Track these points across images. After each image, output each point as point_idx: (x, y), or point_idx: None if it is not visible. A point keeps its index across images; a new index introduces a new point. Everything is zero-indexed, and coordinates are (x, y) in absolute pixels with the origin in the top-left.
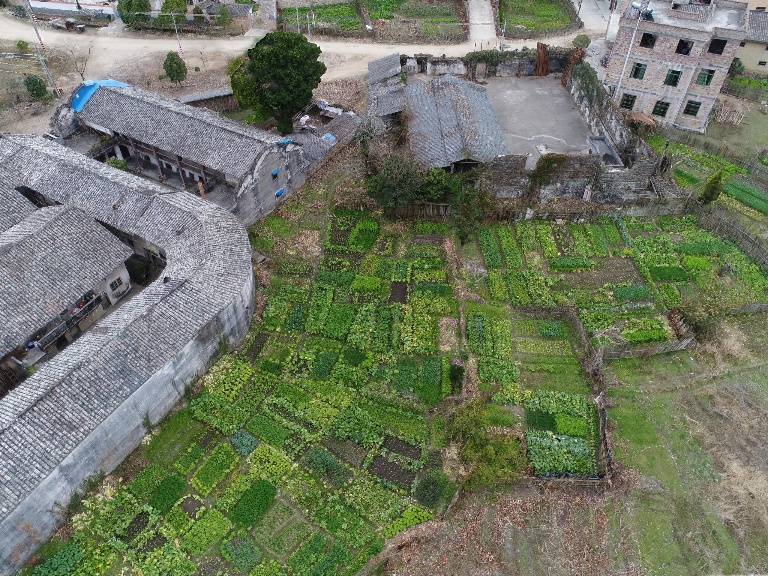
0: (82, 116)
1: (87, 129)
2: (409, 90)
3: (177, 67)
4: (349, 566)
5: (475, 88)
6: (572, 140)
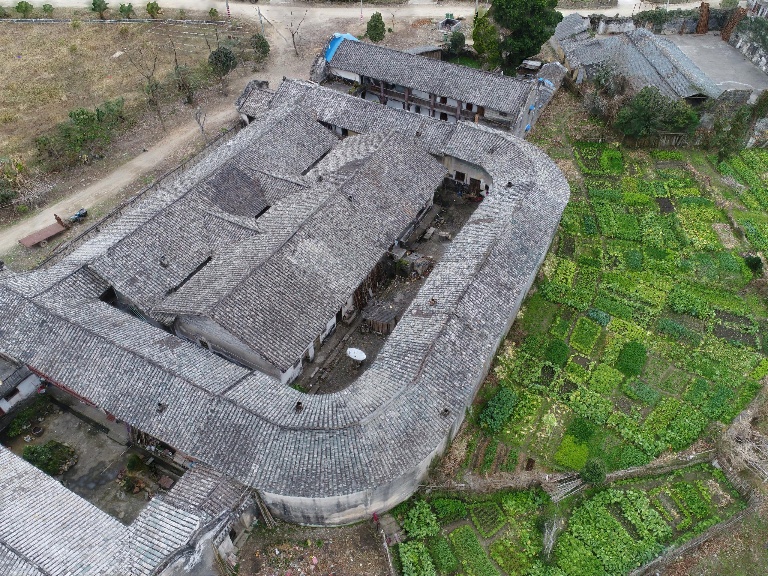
0: (333, 65)
1: (333, 78)
2: (606, 42)
3: (381, 27)
4: (737, 400)
5: (665, 40)
6: (757, 85)
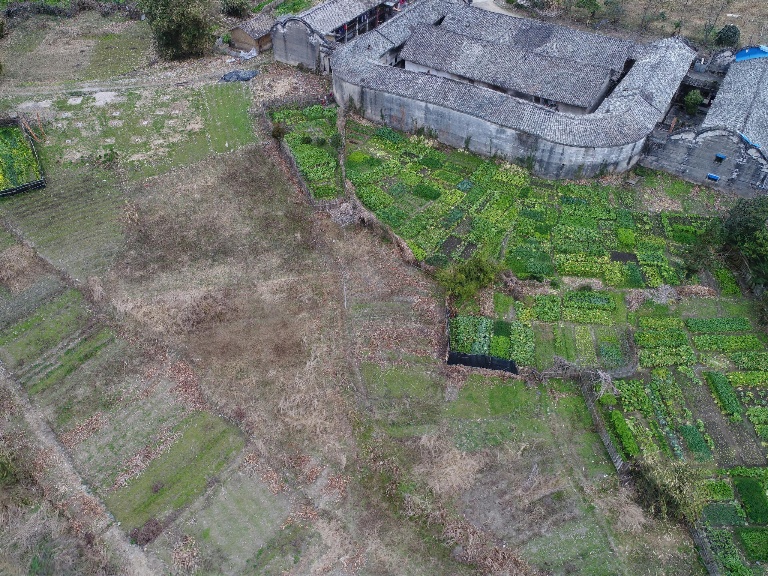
0: (733, 64)
1: None
2: None
3: None
4: None
5: None
6: None
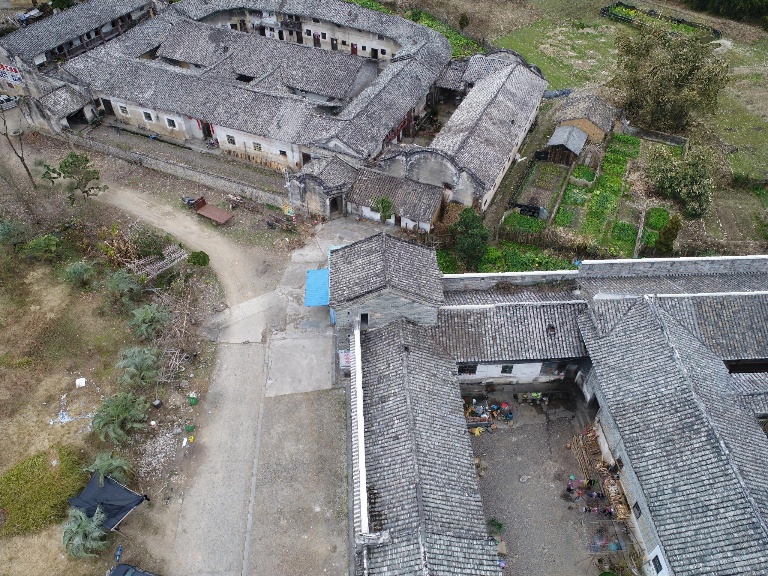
0: None
1: None
2: None
3: None
4: (368, 3)
5: None
6: None
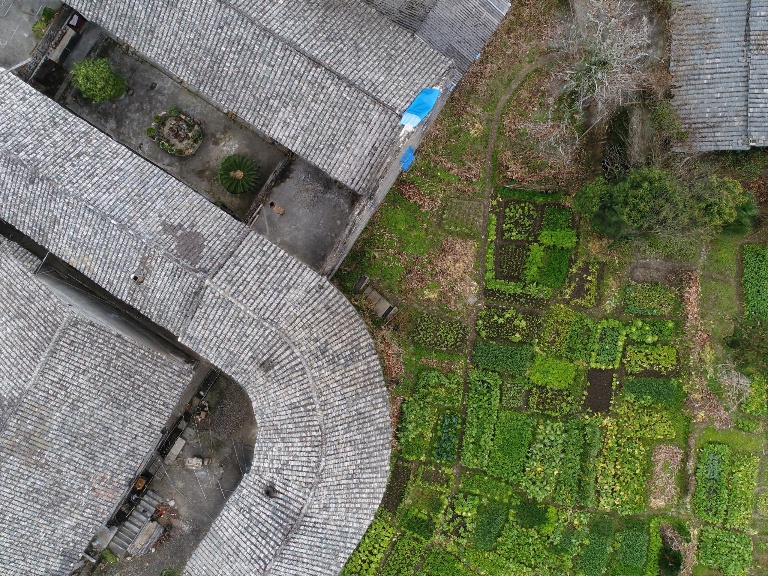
0: None
1: None
2: None
3: None
4: None
5: None
6: None
